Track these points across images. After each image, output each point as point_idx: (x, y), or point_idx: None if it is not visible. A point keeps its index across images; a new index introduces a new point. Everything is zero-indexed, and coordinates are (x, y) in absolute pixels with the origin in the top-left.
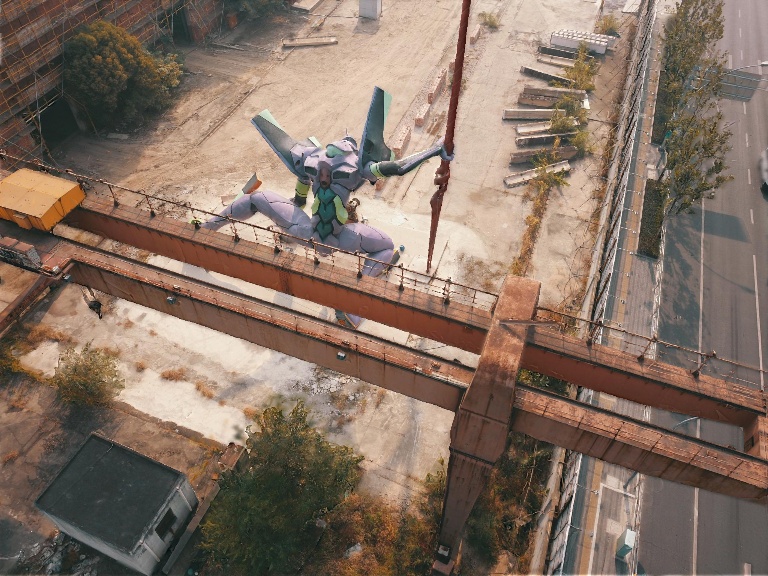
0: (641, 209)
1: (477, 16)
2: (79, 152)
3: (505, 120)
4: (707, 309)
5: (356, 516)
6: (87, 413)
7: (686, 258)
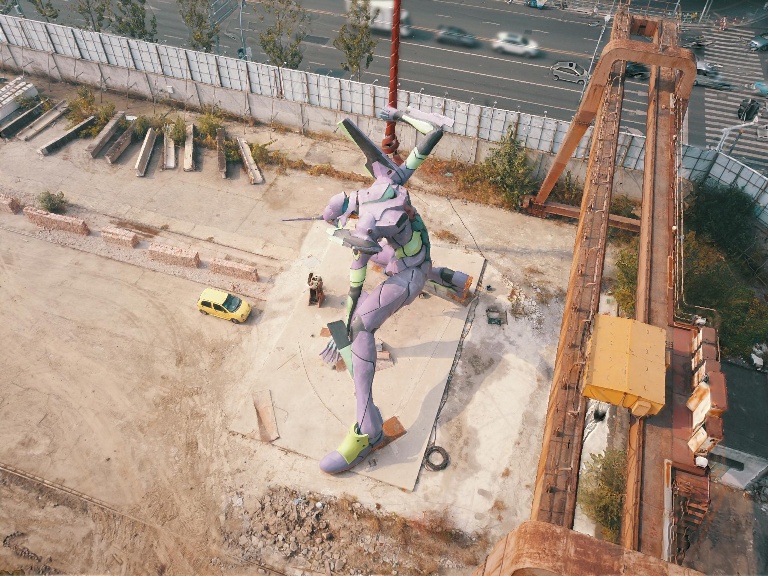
0: None
1: None
2: None
3: (145, 175)
4: None
5: None
6: None
7: None
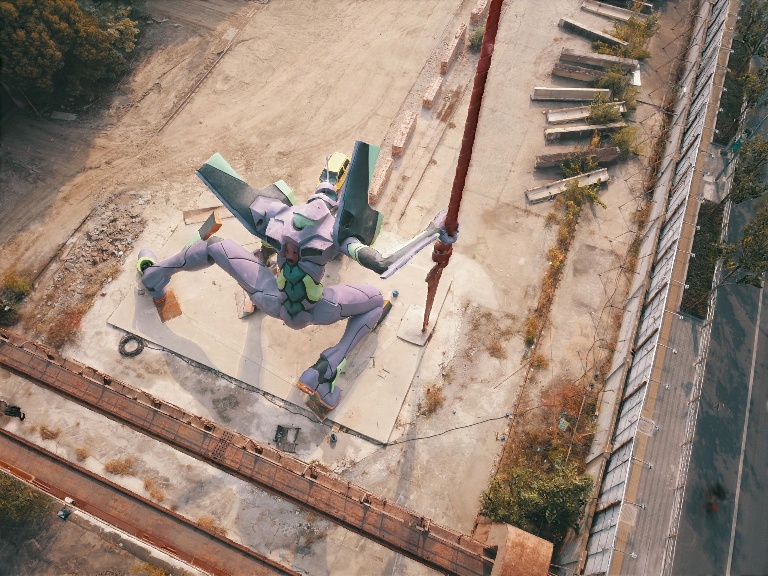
0: (691, 244)
1: None
2: (17, 139)
3: (534, 101)
4: (757, 394)
5: None
6: None
7: (739, 318)
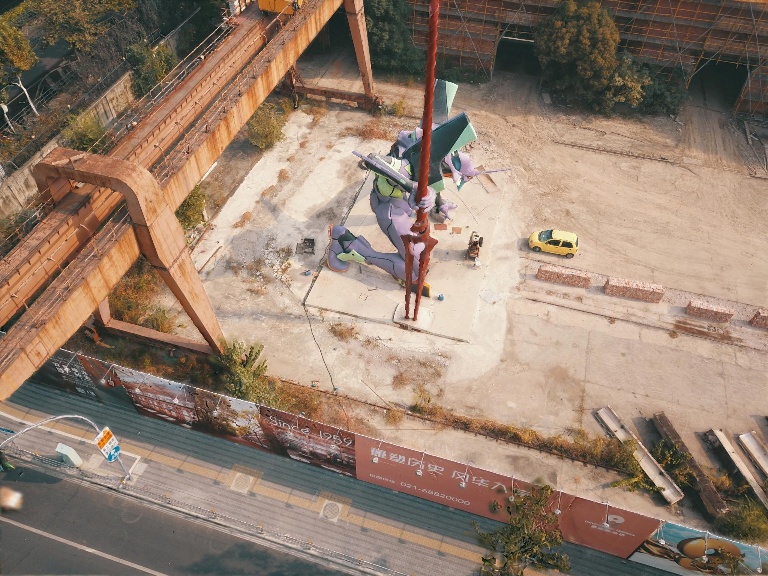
0: None
1: None
2: (516, 85)
3: (767, 420)
4: None
5: (147, 276)
6: (255, 145)
7: None
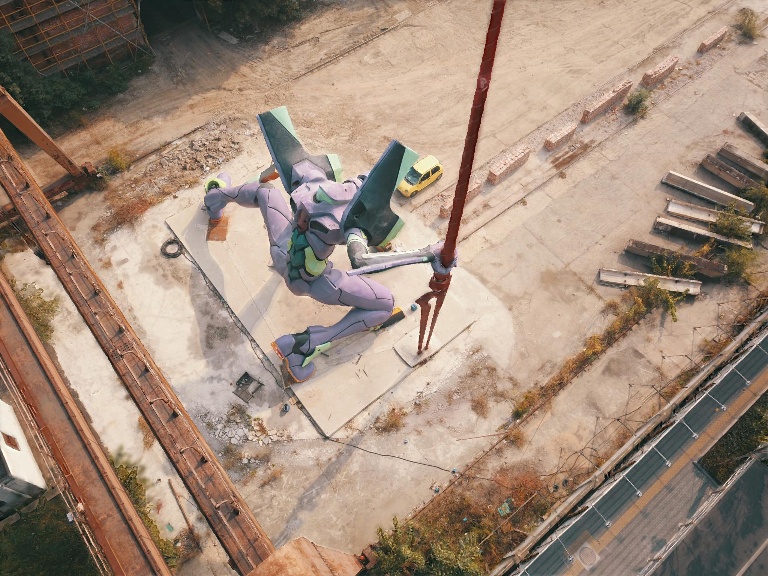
0: (753, 401)
1: (737, 11)
2: (184, 44)
3: (664, 184)
4: None
5: None
6: None
7: (764, 504)
